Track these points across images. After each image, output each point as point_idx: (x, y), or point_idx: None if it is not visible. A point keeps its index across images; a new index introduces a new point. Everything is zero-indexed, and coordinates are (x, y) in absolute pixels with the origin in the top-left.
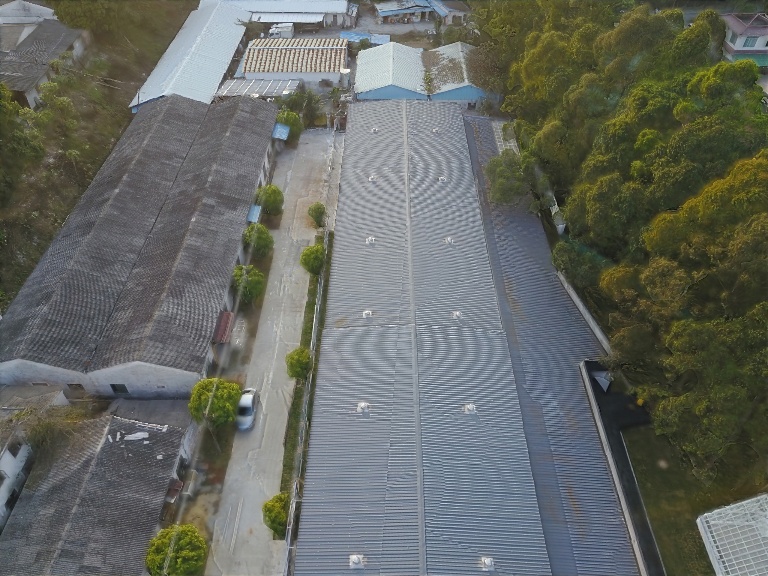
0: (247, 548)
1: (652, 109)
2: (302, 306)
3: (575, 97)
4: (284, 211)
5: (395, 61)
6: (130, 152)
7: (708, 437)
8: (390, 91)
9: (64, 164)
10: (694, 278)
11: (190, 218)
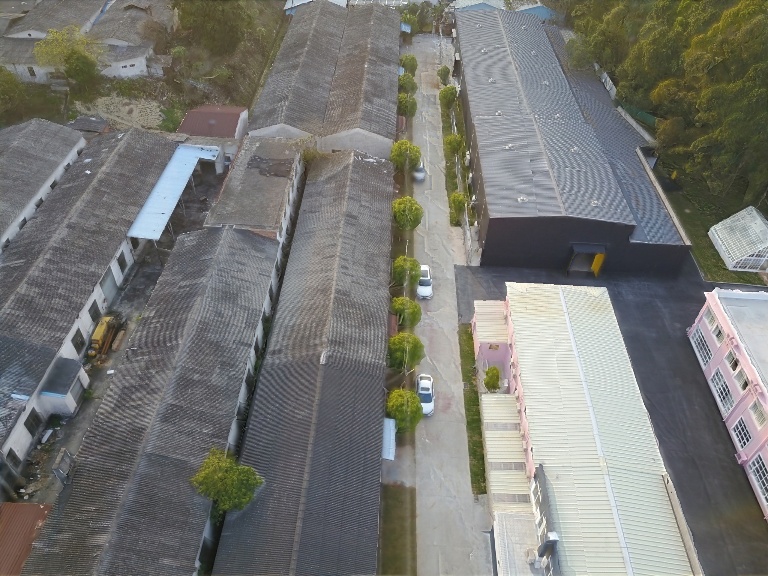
0: (436, 228)
1: None
2: (440, 128)
3: None
4: None
5: None
6: (304, 30)
7: (719, 157)
8: (481, 8)
9: (253, 38)
10: (716, 60)
11: (363, 65)
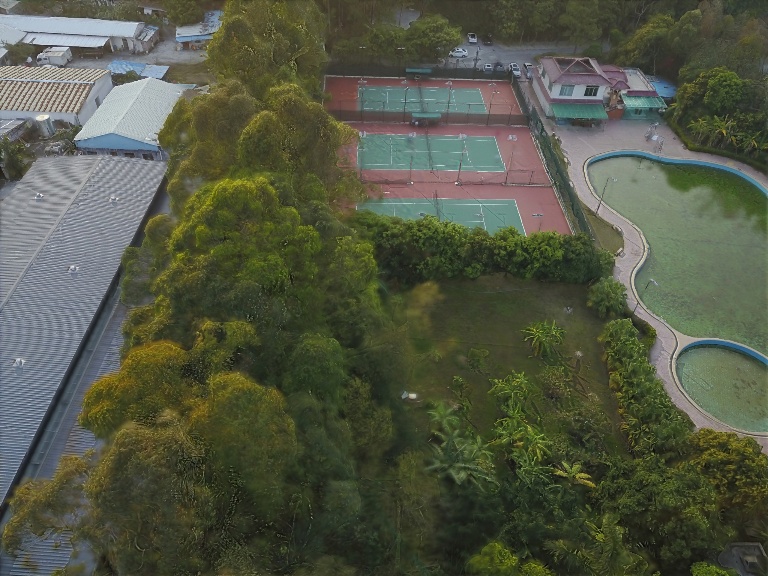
0: None
1: (189, 226)
2: None
3: None
4: None
5: (137, 102)
6: None
7: None
8: (113, 140)
9: None
10: None
11: None
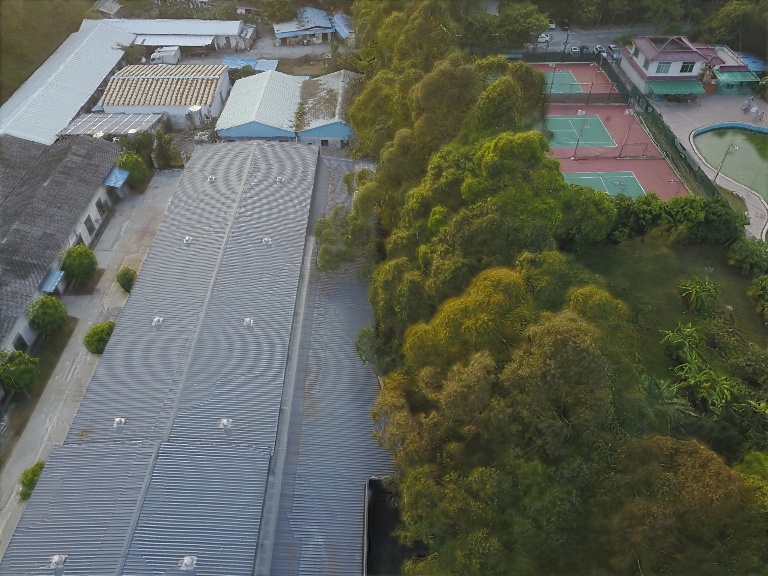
0: None
1: (444, 182)
2: None
3: (385, 157)
4: (105, 271)
5: (266, 93)
6: None
7: None
8: (253, 128)
9: None
10: (422, 422)
11: None
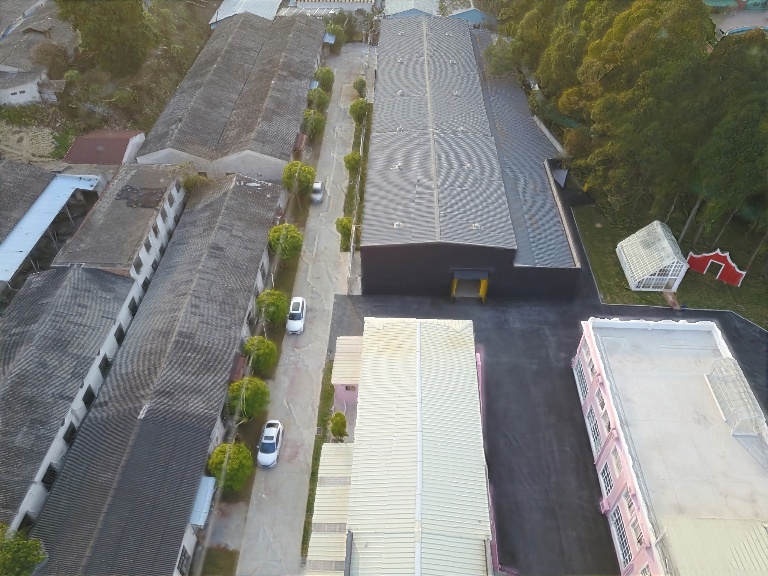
0: (324, 255)
1: None
2: (350, 143)
3: None
4: (333, 92)
5: None
6: (219, 46)
7: (615, 171)
8: (412, 14)
9: (168, 56)
10: (606, 68)
11: (270, 81)
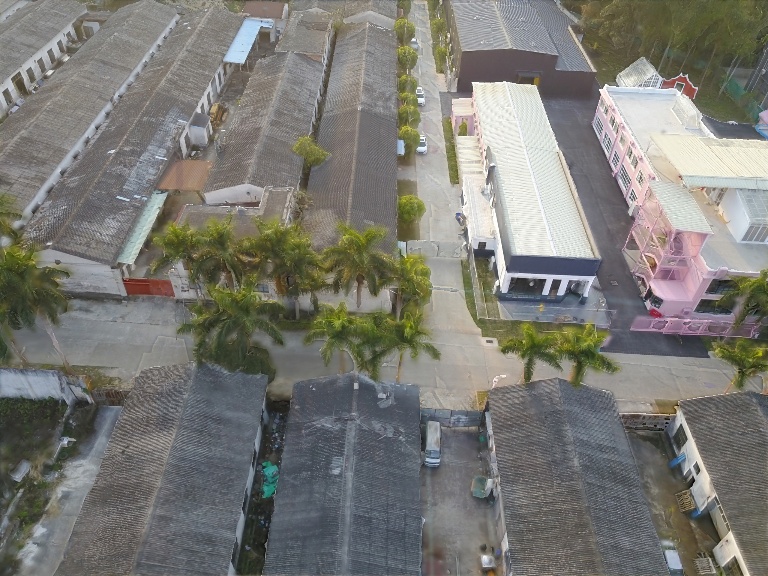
0: (426, 74)
1: None
2: (428, 23)
3: None
4: None
5: None
6: None
7: None
8: None
9: None
10: None
11: None
